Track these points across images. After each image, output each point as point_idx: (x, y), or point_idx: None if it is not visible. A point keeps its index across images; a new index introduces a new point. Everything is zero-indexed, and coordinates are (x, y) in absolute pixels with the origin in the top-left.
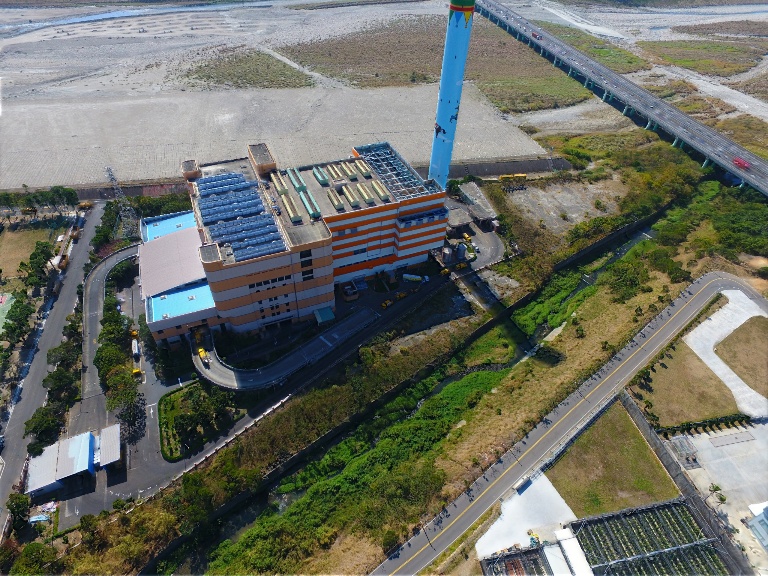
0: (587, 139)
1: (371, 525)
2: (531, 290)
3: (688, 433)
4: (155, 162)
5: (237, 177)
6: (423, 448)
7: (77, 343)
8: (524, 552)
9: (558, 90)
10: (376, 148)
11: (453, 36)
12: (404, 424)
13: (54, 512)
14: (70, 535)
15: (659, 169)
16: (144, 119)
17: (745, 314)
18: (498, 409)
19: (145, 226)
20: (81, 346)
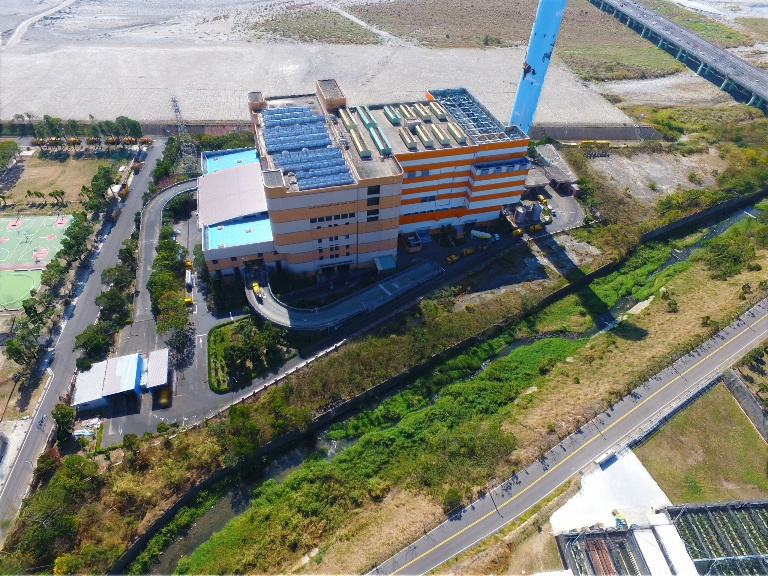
0: (679, 111)
1: (429, 482)
2: (614, 259)
3: None
4: (218, 105)
5: (304, 111)
6: (488, 410)
7: (131, 266)
8: (609, 533)
9: (646, 61)
10: (452, 94)
11: None
12: (467, 383)
13: (98, 428)
14: (112, 453)
15: (765, 146)
16: (209, 65)
17: None
18: (576, 378)
19: (206, 159)
20: (135, 272)
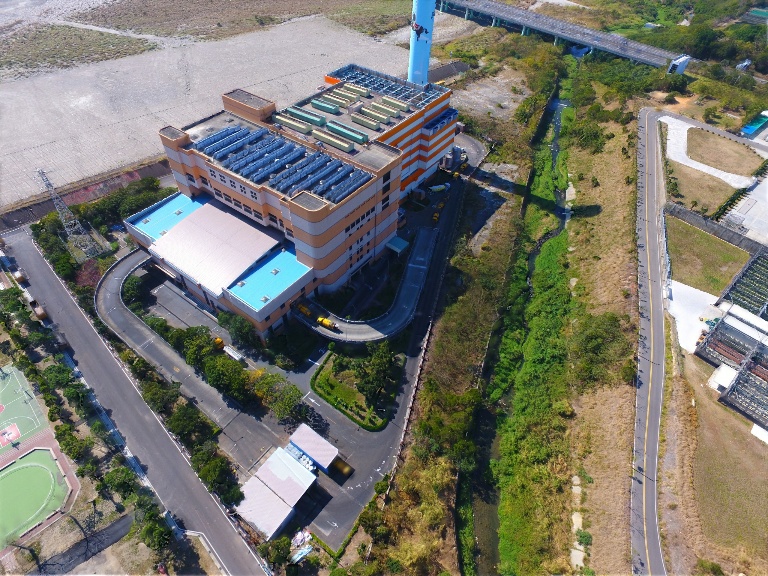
0: (458, 44)
1: (596, 378)
2: (530, 167)
3: (725, 213)
4: None
5: (236, 131)
6: (566, 311)
7: None
8: None
9: (399, 9)
10: (343, 72)
11: None
12: (534, 302)
13: (311, 539)
14: (351, 546)
15: (532, 53)
16: None
17: (683, 129)
18: (595, 256)
19: None
20: (161, 383)
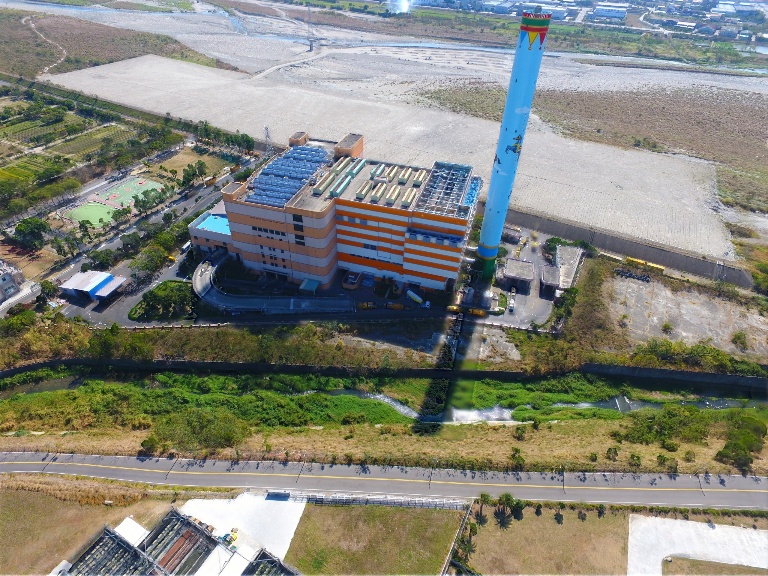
0: None
1: None
2: (524, 370)
3: None
4: None
5: None
6: (267, 421)
7: None
8: (207, 535)
9: None
10: (459, 169)
11: (517, 57)
12: (278, 396)
13: (60, 306)
14: None
15: None
16: (357, 115)
17: None
18: (350, 435)
19: None
20: None
